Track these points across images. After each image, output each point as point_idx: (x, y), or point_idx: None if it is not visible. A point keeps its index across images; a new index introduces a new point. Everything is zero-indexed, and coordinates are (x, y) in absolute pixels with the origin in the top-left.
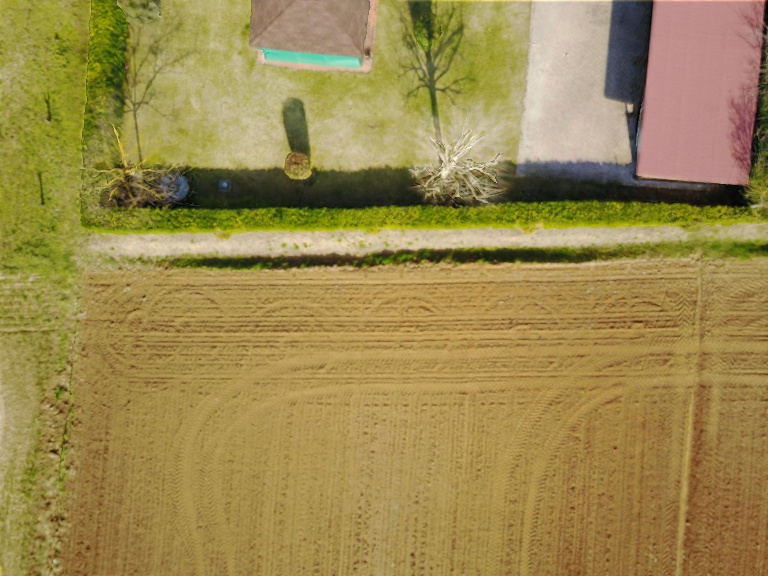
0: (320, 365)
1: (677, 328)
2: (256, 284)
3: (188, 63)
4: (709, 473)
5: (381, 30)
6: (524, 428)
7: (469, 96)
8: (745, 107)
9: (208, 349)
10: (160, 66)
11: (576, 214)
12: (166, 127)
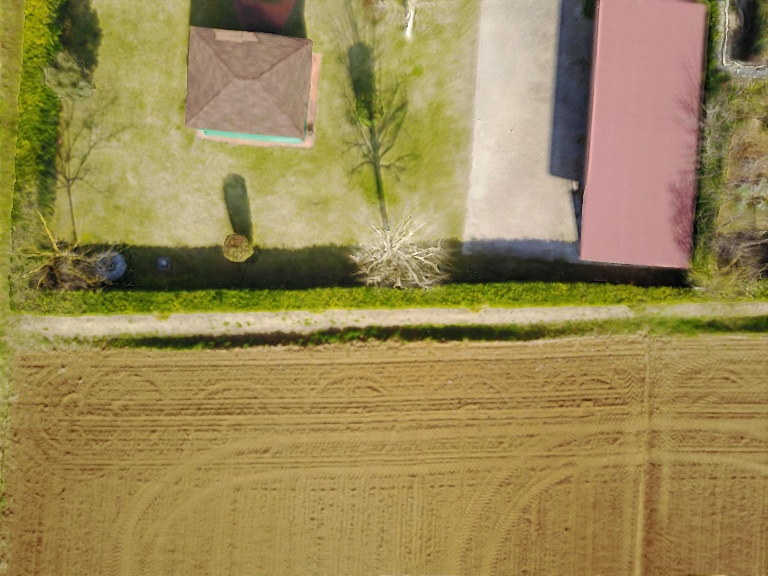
0: (264, 449)
1: (626, 406)
2: (197, 365)
3: (124, 138)
4: (660, 553)
5: (324, 105)
6: (474, 511)
7: (414, 172)
8: (687, 190)
9: (147, 434)
10: (95, 141)
11: (522, 295)
12: (102, 204)
